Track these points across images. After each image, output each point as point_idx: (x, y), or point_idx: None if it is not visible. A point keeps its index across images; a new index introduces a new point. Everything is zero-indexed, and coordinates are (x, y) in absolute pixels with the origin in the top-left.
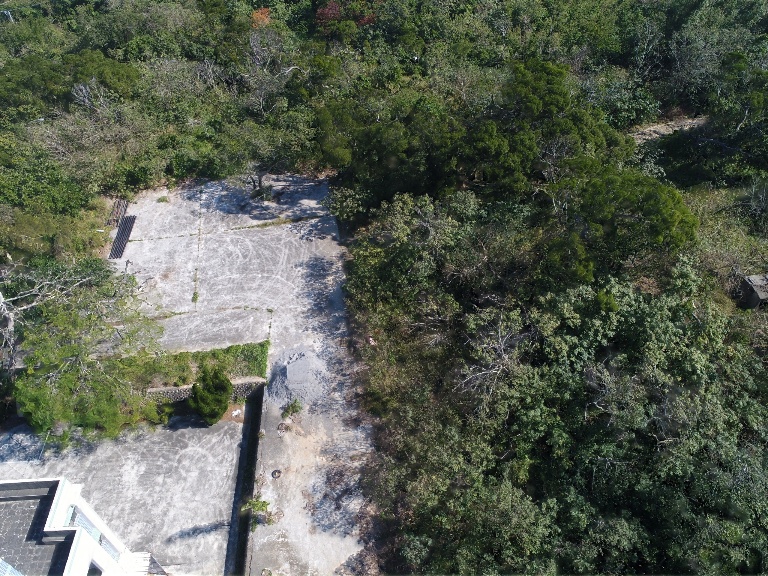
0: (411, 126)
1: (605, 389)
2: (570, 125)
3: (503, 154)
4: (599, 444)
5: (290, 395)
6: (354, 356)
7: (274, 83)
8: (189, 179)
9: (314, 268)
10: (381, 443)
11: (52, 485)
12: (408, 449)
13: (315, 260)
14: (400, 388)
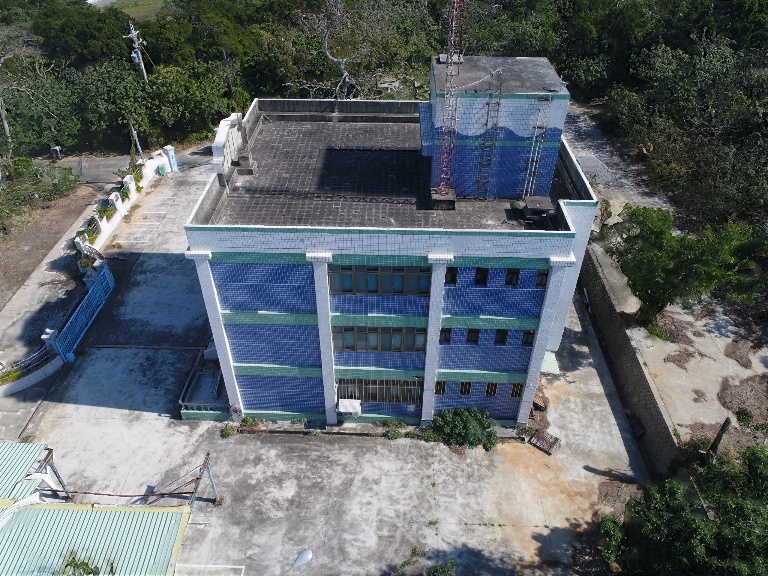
0: (657, 2)
1: None
2: None
3: (754, 11)
4: None
5: None
6: (629, 161)
7: (490, 7)
8: None
9: None
10: (683, 202)
11: None
12: None
13: None
14: None
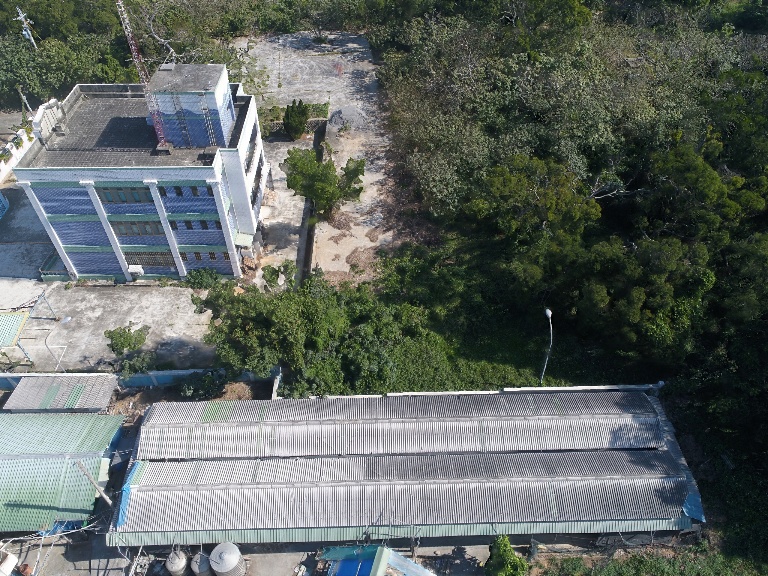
0: None
1: None
2: None
3: None
4: None
5: (343, 123)
6: (383, 109)
7: None
8: (270, 32)
9: (357, 74)
10: (398, 140)
11: (235, 88)
12: (414, 140)
13: (358, 70)
14: None
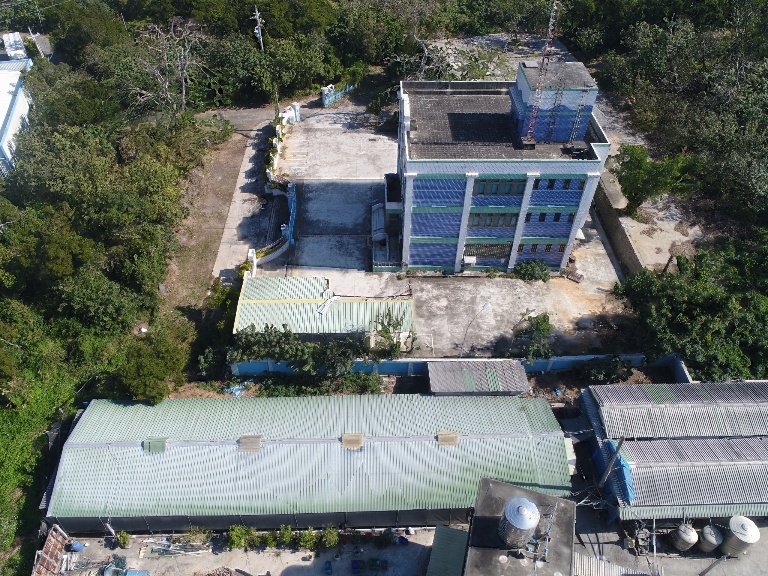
0: None
1: None
2: None
3: None
4: None
5: None
6: (619, 110)
7: None
8: (461, 34)
9: None
10: (654, 139)
11: None
12: None
13: None
14: None
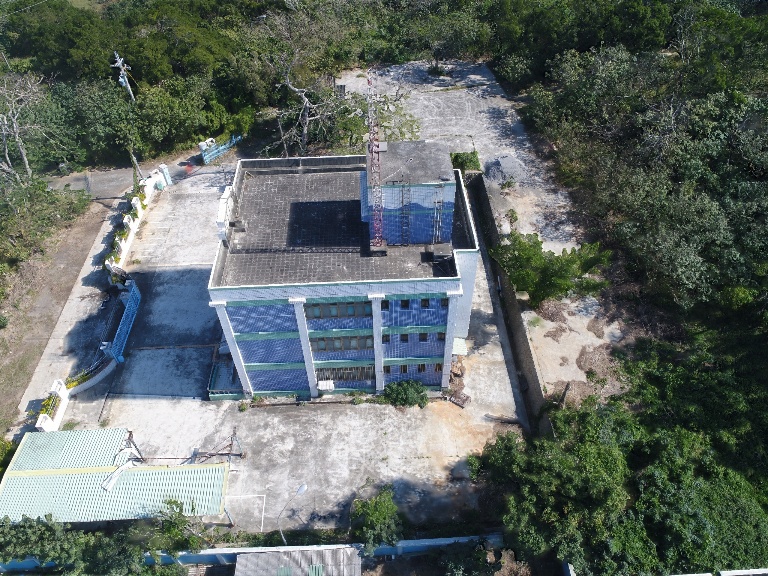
0: (570, 5)
1: (743, 145)
2: (691, 3)
3: (647, 18)
4: (738, 182)
5: (504, 177)
6: (542, 158)
7: None
8: (376, 63)
9: (494, 113)
10: (578, 198)
11: None
12: None
13: (493, 109)
14: (582, 172)
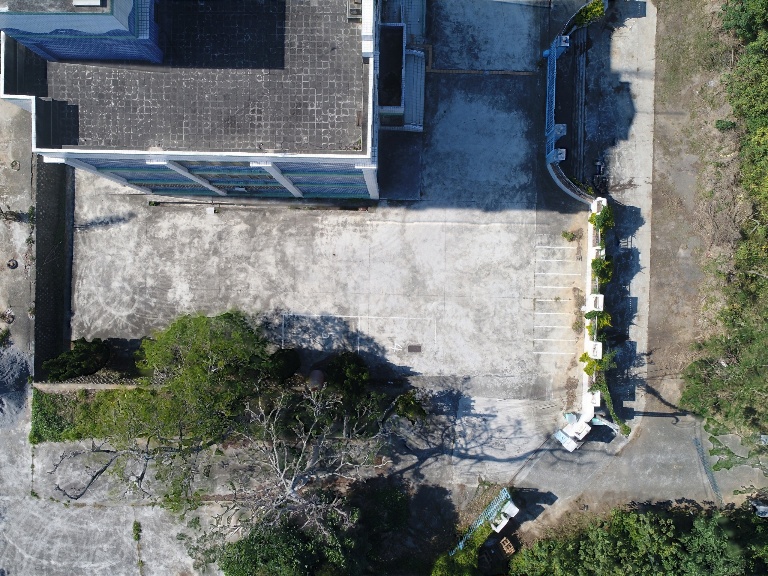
0: None
1: None
2: None
3: None
4: None
5: None
6: None
7: None
8: None
9: None
10: None
11: None
12: None
13: None
14: None
